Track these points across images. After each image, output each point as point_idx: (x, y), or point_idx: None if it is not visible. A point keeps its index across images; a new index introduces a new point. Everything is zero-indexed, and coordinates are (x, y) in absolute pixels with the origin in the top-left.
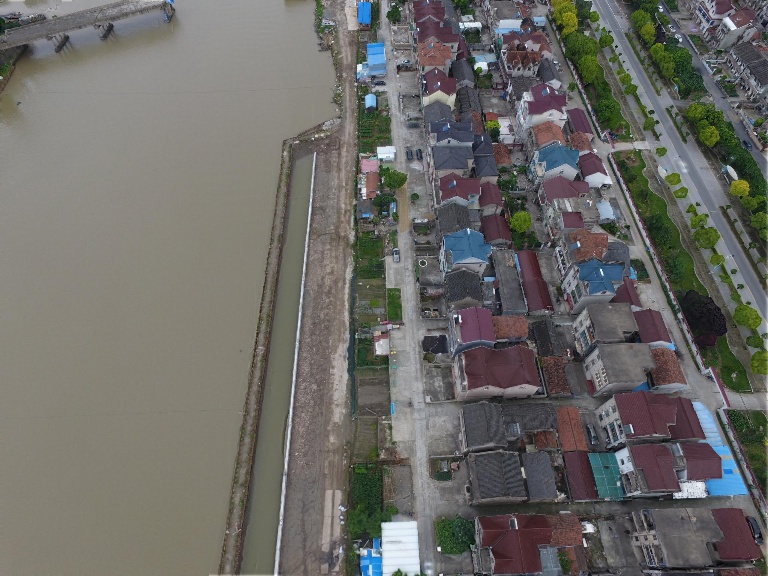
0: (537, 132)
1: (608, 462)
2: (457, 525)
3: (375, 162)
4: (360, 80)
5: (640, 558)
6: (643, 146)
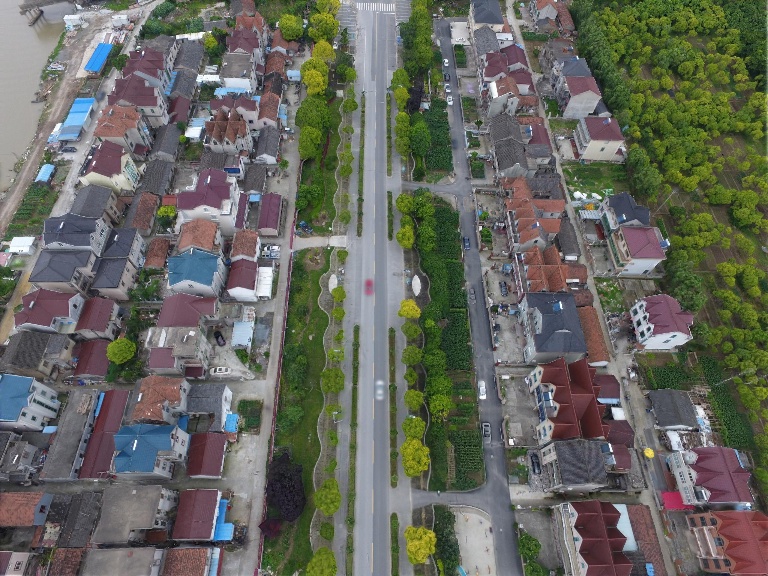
0: (184, 231)
1: None
2: None
3: (4, 257)
4: (48, 144)
5: None
6: (339, 242)
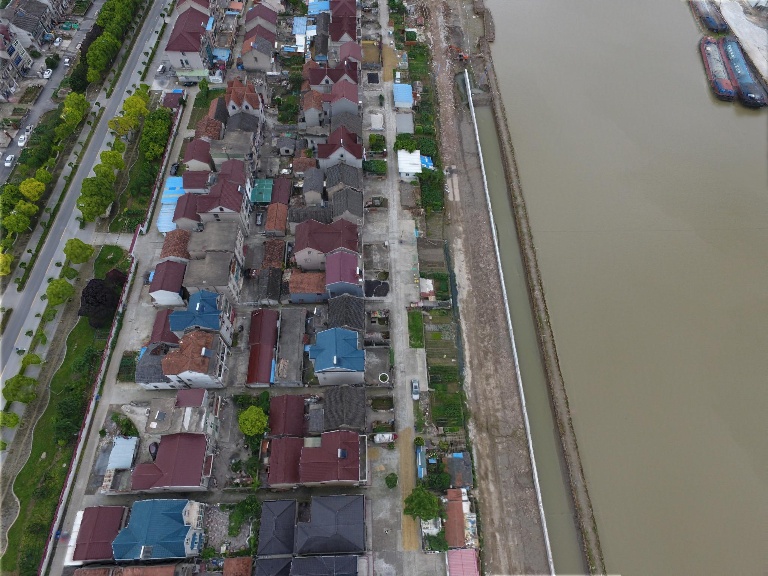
0: None
1: (258, 196)
2: (374, 166)
3: (455, 575)
4: None
5: (258, 160)
6: None
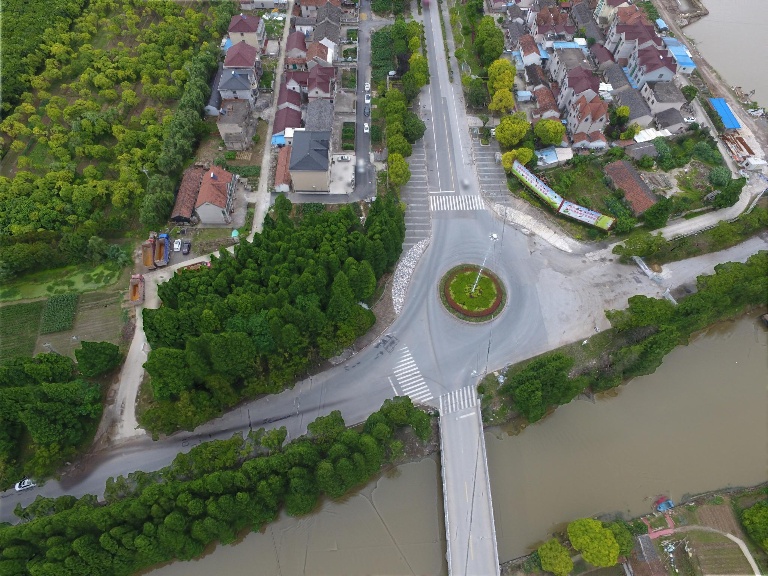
0: None
1: None
2: None
3: None
4: None
5: None
6: None
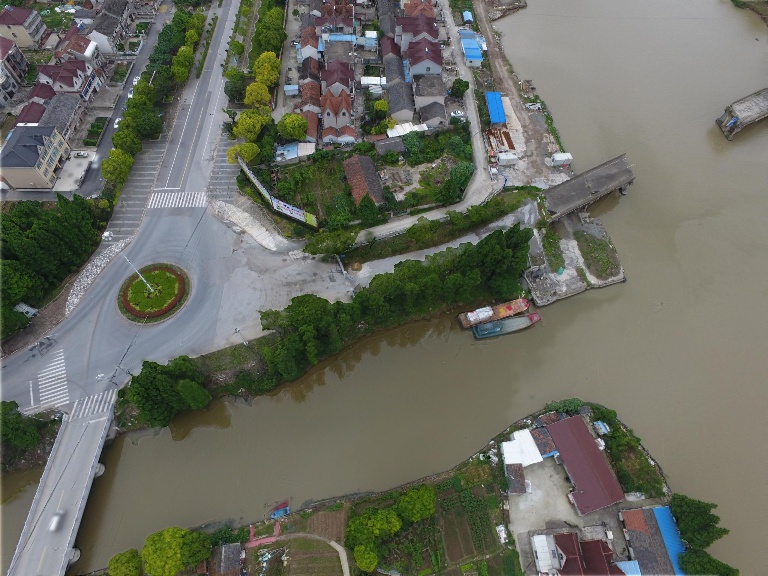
0: None
1: None
2: None
3: None
4: None
5: None
6: None
